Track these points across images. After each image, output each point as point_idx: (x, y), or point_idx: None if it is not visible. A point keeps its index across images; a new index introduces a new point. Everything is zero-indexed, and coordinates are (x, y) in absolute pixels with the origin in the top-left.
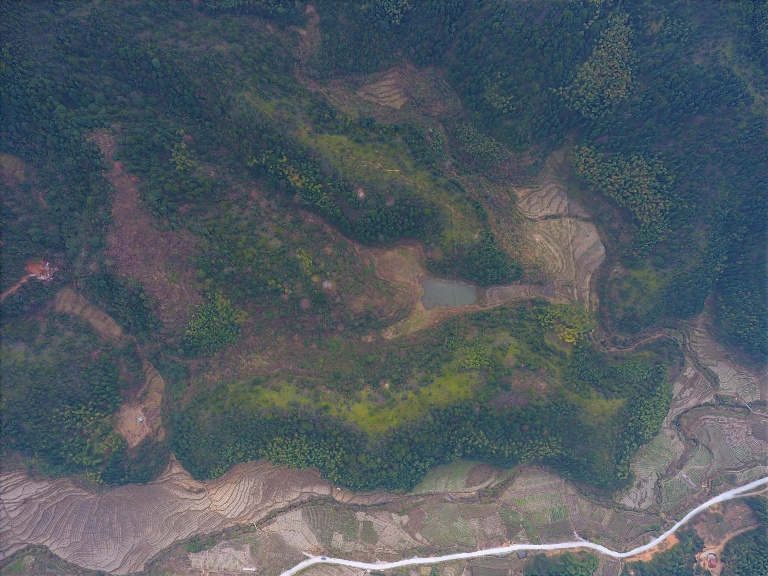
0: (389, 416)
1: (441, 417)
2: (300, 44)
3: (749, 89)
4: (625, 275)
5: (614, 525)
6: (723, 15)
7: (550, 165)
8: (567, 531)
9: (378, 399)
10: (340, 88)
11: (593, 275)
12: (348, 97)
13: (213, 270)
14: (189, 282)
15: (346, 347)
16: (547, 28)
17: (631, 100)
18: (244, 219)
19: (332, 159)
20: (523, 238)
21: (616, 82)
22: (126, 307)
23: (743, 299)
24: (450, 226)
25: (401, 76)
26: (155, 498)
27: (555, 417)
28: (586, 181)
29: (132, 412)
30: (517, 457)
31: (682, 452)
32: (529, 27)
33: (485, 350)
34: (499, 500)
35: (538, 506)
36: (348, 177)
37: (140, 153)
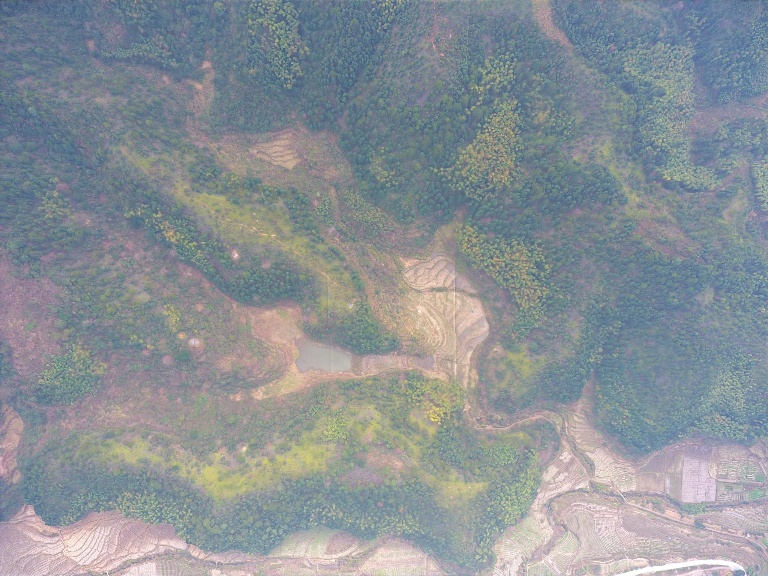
0: (238, 482)
1: (293, 487)
2: (195, 98)
3: (624, 189)
4: (502, 356)
5: None
6: (604, 113)
7: (439, 238)
8: None
9: (231, 463)
10: (232, 144)
11: (475, 351)
12: (240, 154)
13: (74, 320)
14: (47, 331)
15: (212, 405)
16: (428, 110)
17: (513, 186)
18: (114, 270)
19: (207, 219)
20: (405, 309)
21: (500, 167)
22: None
23: (617, 392)
24: (325, 294)
25: (295, 138)
26: (8, 538)
27: (410, 497)
28: (469, 259)
29: None
30: (375, 530)
31: (550, 537)
32: (411, 107)
33: (346, 422)
34: (358, 570)
35: None
36: (222, 238)
37: (7, 199)
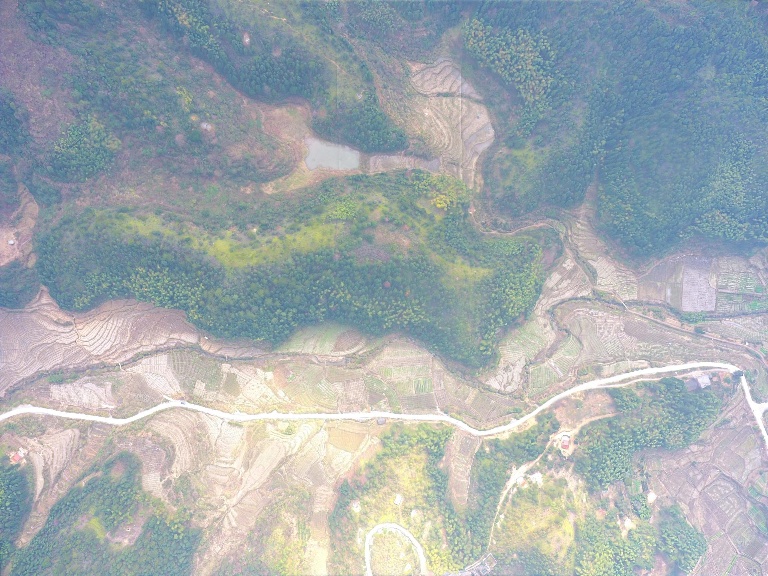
0: (249, 254)
1: (303, 263)
2: None
3: None
4: (507, 154)
5: (477, 404)
6: None
7: (446, 42)
8: (429, 405)
9: (242, 239)
10: None
11: (480, 156)
12: None
13: (89, 93)
14: (63, 100)
15: (223, 194)
16: None
17: None
18: (128, 51)
19: None
20: (412, 110)
21: None
22: (1, 121)
23: (620, 187)
24: (334, 83)
25: None
26: (23, 327)
27: (417, 276)
28: (476, 56)
29: (4, 234)
30: (382, 321)
31: (553, 341)
32: None
33: (354, 204)
34: (365, 367)
35: (403, 378)
36: (234, 19)
37: None
